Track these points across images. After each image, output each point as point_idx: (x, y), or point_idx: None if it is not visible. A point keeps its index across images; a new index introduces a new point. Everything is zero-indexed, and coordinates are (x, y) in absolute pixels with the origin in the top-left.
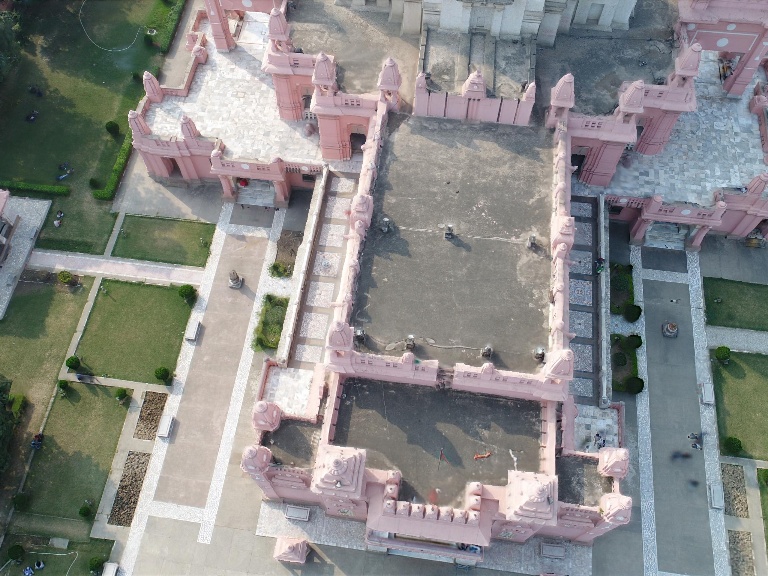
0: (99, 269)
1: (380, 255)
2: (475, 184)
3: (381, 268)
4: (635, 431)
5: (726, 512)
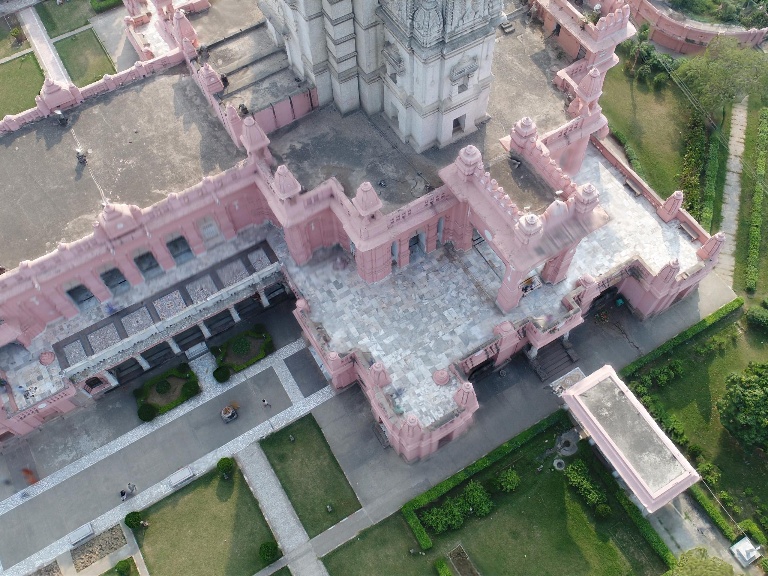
0: (39, 44)
1: (38, 133)
2: (147, 148)
3: (26, 140)
4: (110, 439)
5: (73, 550)
